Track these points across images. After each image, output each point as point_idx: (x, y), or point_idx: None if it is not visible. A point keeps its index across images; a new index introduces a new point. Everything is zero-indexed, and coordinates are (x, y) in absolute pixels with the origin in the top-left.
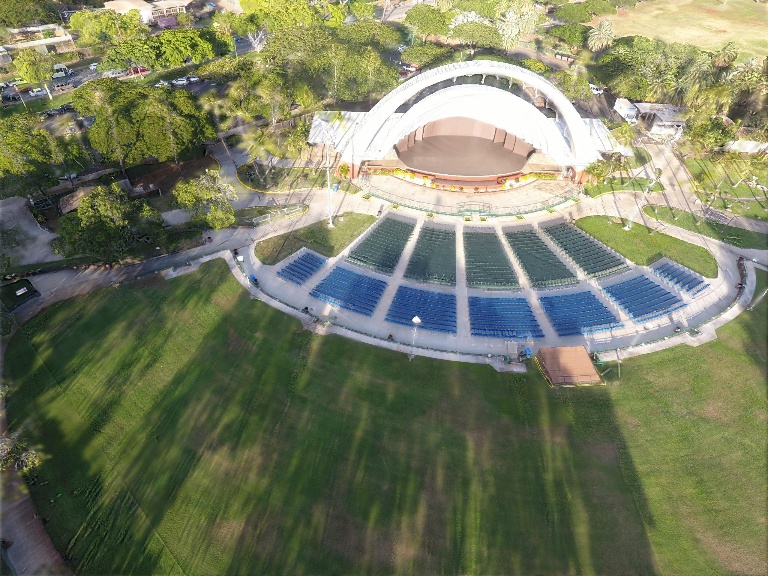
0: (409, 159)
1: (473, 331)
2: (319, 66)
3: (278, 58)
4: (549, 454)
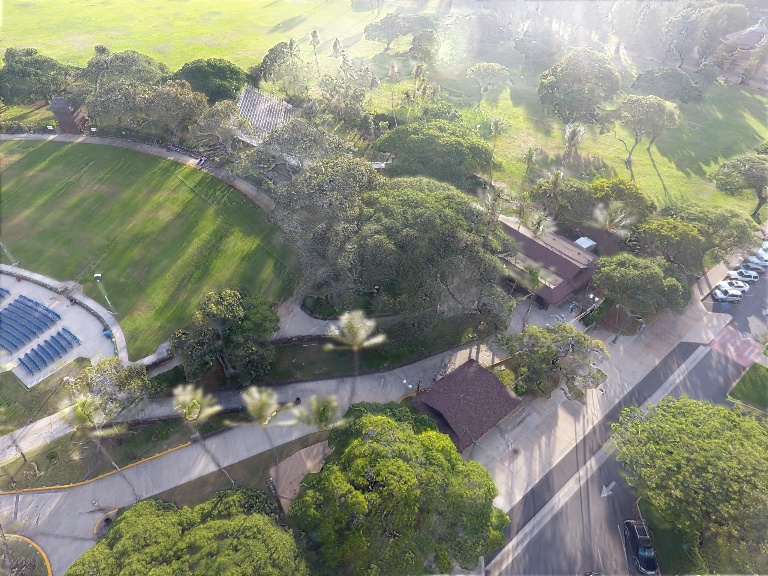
0: None
1: None
2: None
3: None
4: None
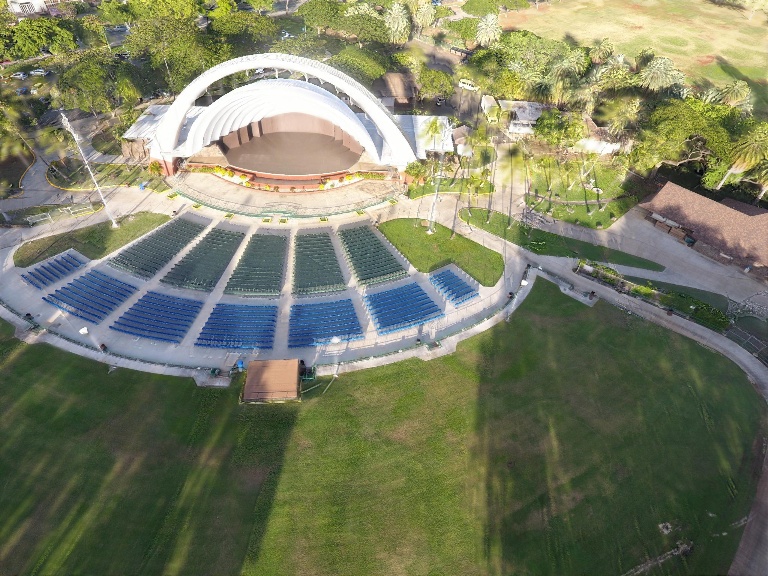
0: (235, 156)
1: (197, 341)
2: (161, 58)
3: (135, 49)
4: (193, 478)
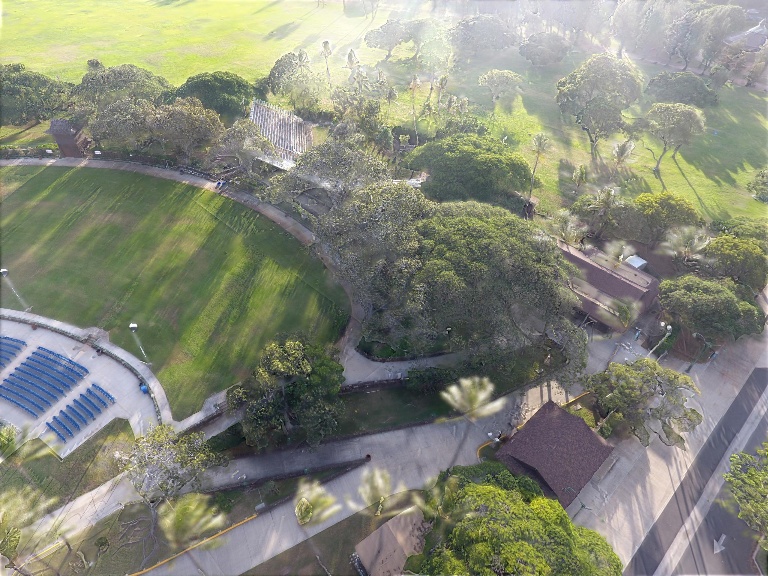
0: None
1: None
2: None
3: None
4: None
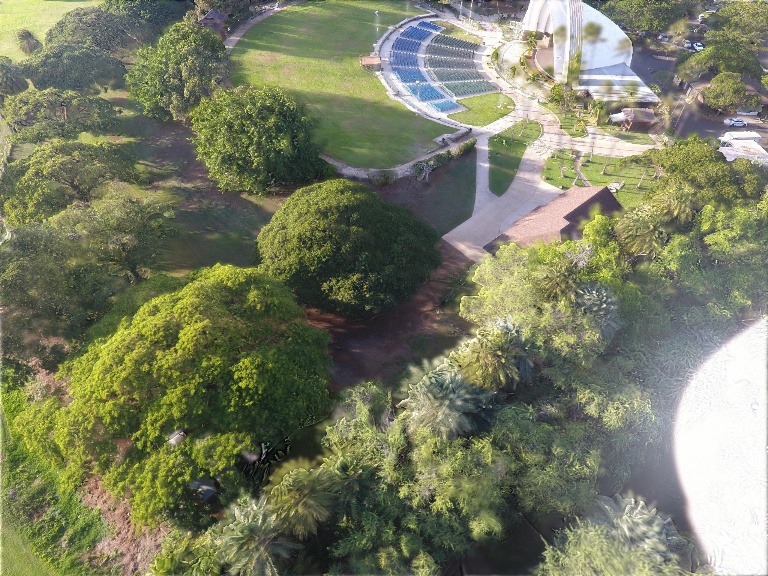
0: (550, 50)
1: None
2: None
3: None
4: None
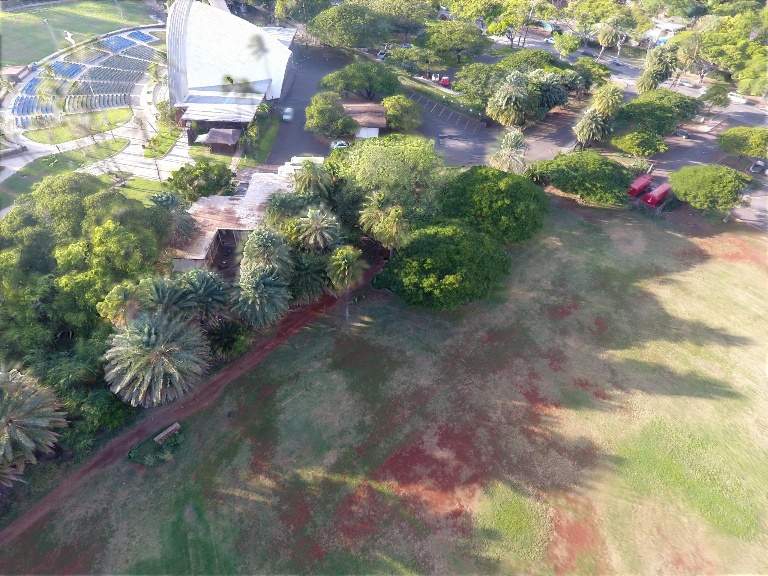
0: None
1: None
2: None
3: None
4: None
